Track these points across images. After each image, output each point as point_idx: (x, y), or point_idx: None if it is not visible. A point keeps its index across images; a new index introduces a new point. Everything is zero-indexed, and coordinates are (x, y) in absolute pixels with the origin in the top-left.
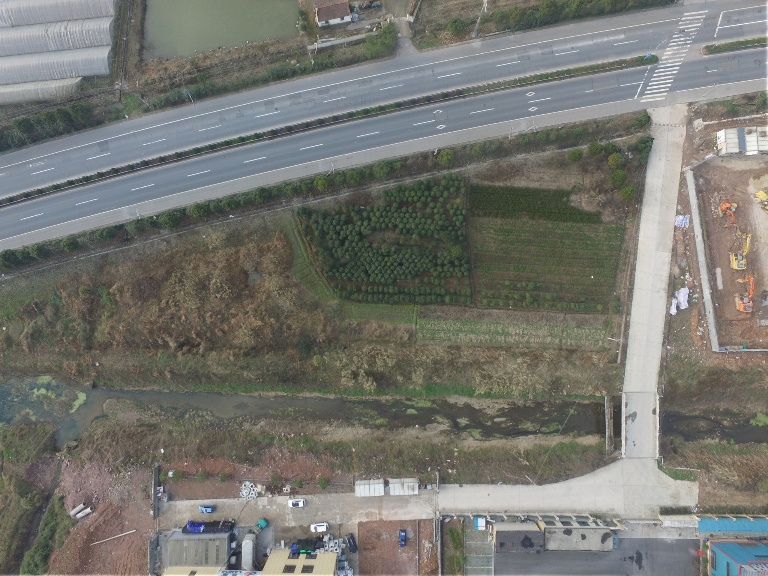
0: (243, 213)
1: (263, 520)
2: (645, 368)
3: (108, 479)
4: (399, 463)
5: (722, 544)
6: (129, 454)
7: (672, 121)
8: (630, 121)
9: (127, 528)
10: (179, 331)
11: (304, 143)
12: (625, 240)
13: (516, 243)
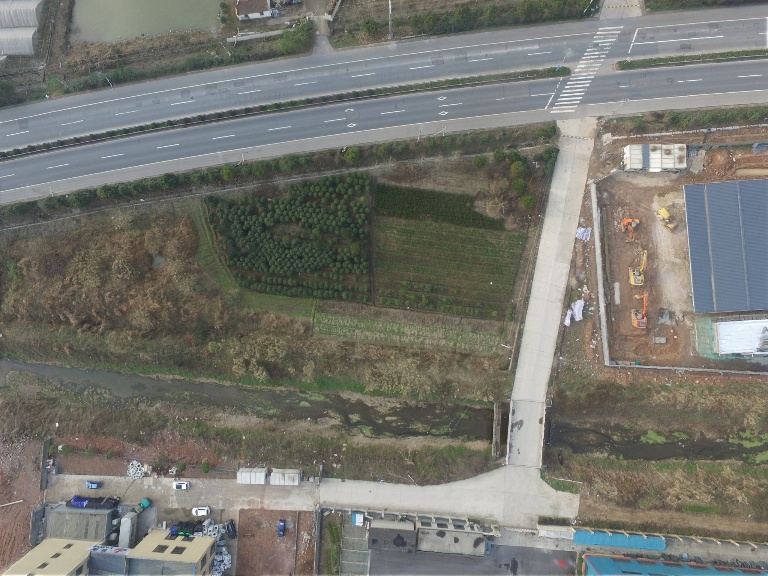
0: (153, 198)
1: (146, 500)
2: (535, 377)
3: (1, 448)
4: (286, 454)
5: (596, 558)
6: (24, 425)
7: (581, 134)
8: (538, 131)
9: (15, 498)
10: (80, 308)
11: (217, 133)
12: (526, 249)
13: (418, 244)
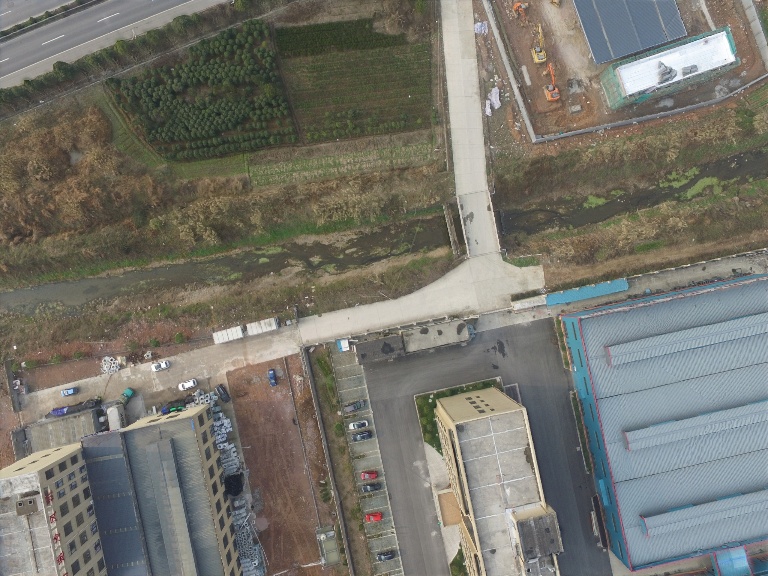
0: (53, 96)
1: (128, 389)
2: (473, 169)
3: None
4: (258, 309)
5: None
6: None
7: None
8: None
9: None
10: (5, 221)
11: (100, 15)
12: (433, 56)
13: (331, 77)
